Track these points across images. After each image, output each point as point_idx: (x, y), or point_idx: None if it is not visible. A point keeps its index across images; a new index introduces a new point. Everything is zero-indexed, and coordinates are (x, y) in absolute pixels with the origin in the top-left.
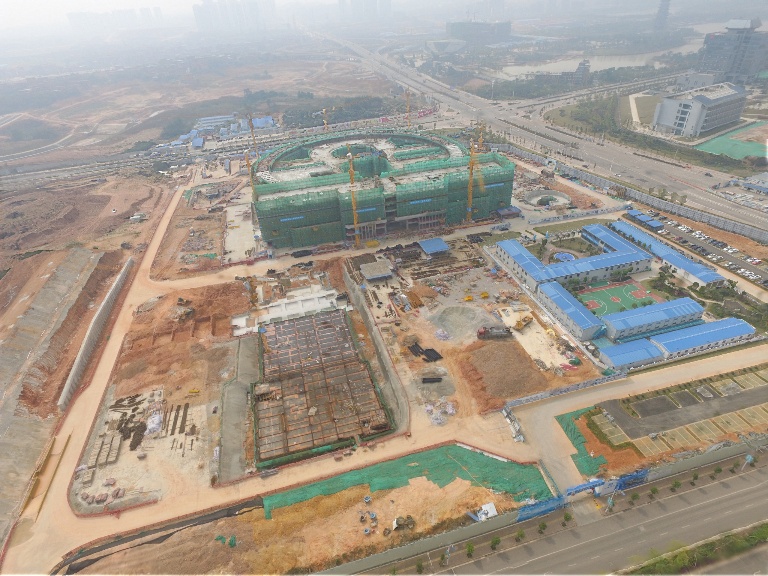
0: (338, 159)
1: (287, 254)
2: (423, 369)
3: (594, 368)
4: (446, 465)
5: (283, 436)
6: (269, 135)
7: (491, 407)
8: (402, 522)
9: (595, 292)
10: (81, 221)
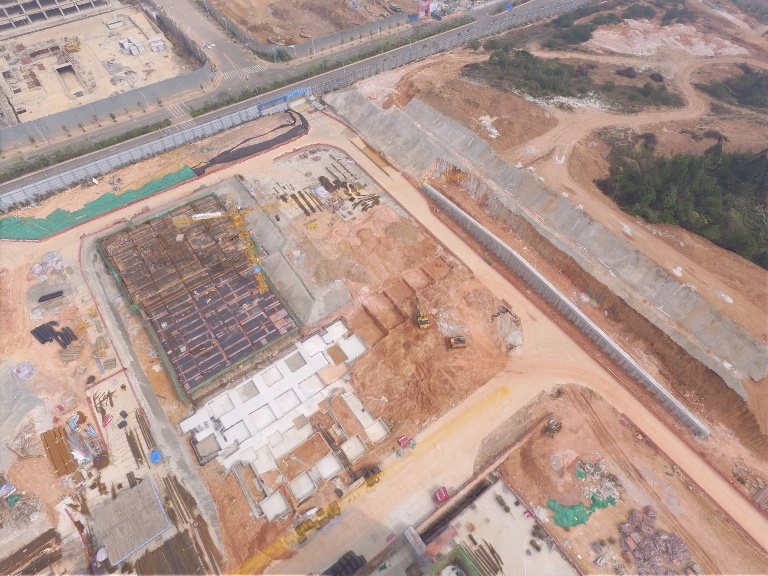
0: None
1: (381, 565)
2: (60, 311)
3: None
4: (52, 223)
5: None
6: None
7: None
8: (87, 177)
9: None
10: None
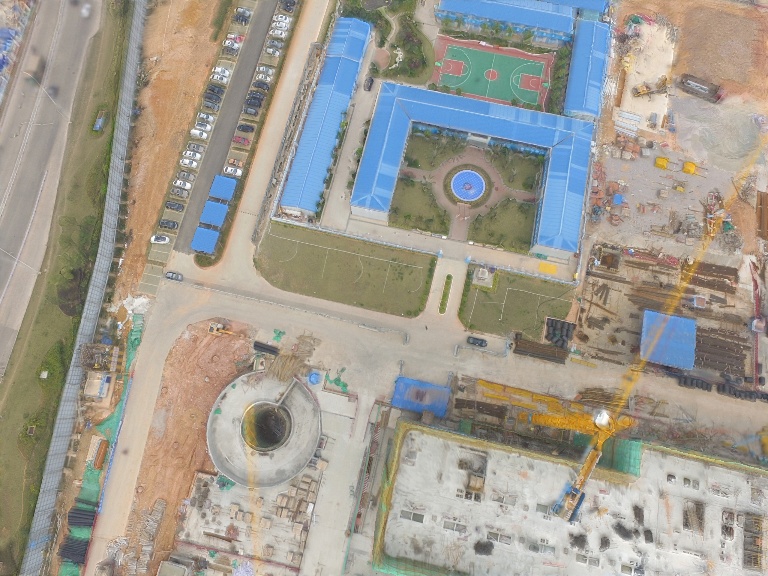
0: None
1: None
2: None
3: (618, 7)
4: None
5: None
6: None
7: (760, 12)
8: None
9: (502, 98)
10: None
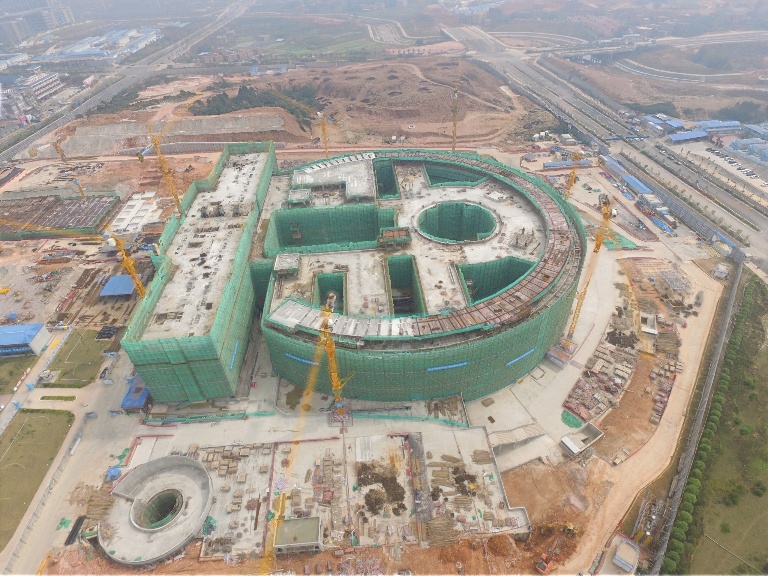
0: (421, 207)
1: None
2: None
3: None
4: None
5: (4, 206)
6: (762, 184)
7: None
8: None
9: None
10: (398, 120)
